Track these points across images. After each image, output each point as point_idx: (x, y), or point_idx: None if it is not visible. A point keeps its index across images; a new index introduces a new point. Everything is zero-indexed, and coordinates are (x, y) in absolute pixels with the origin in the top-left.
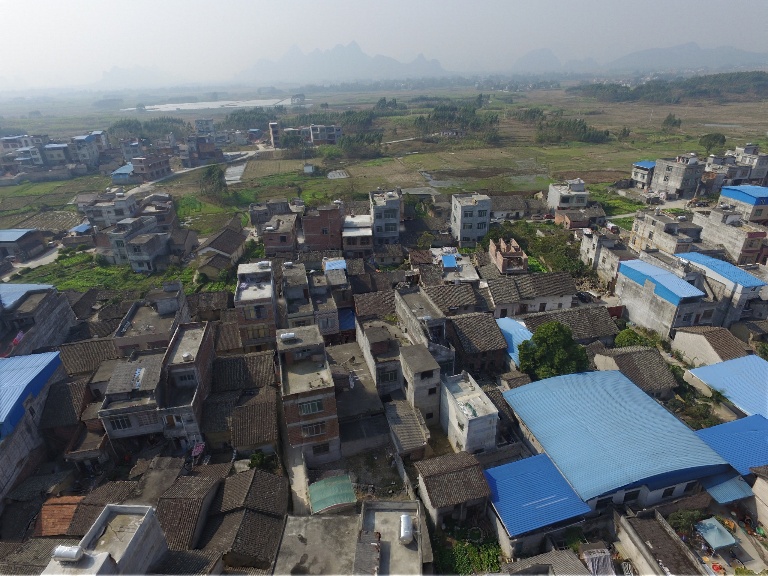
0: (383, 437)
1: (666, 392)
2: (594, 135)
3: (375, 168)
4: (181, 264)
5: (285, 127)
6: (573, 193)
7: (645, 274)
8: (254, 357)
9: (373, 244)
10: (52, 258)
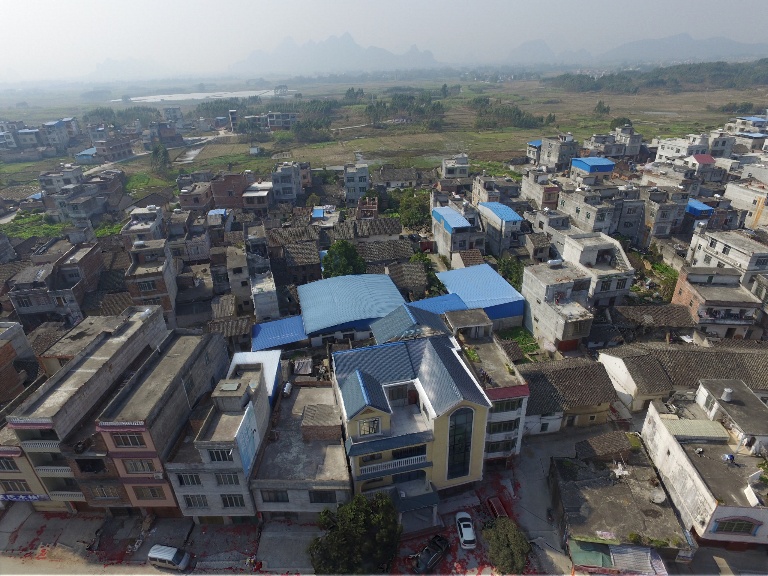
0: (208, 314)
1: (422, 290)
2: (527, 121)
3: (317, 150)
4: (114, 221)
5: (246, 115)
6: (456, 165)
7: (440, 214)
8: None
9: (268, 203)
10: (10, 219)
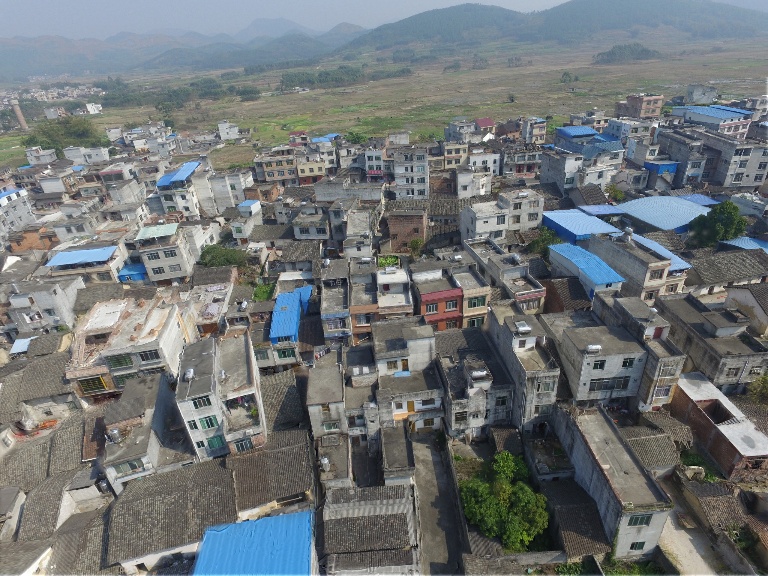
0: None
1: None
2: None
3: None
4: None
5: None
6: None
7: None
8: None
9: None
10: None
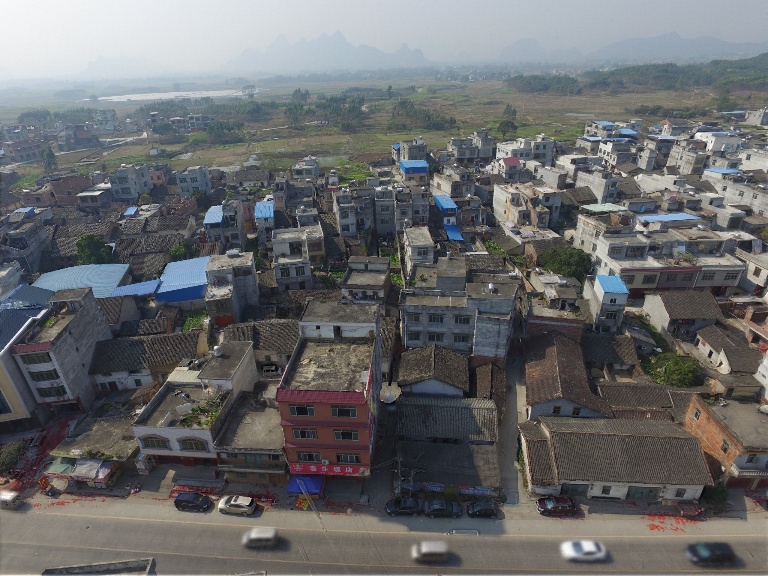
0: None
1: None
2: (435, 123)
3: (219, 151)
4: None
5: (172, 116)
6: (303, 167)
7: None
8: None
9: (102, 202)
10: None
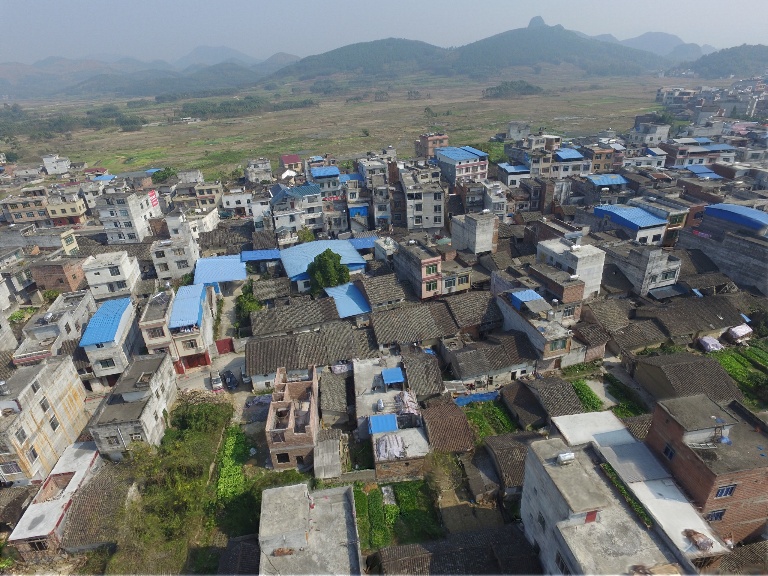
0: None
1: None
2: None
3: None
4: None
5: None
6: None
7: None
8: None
9: None
10: None
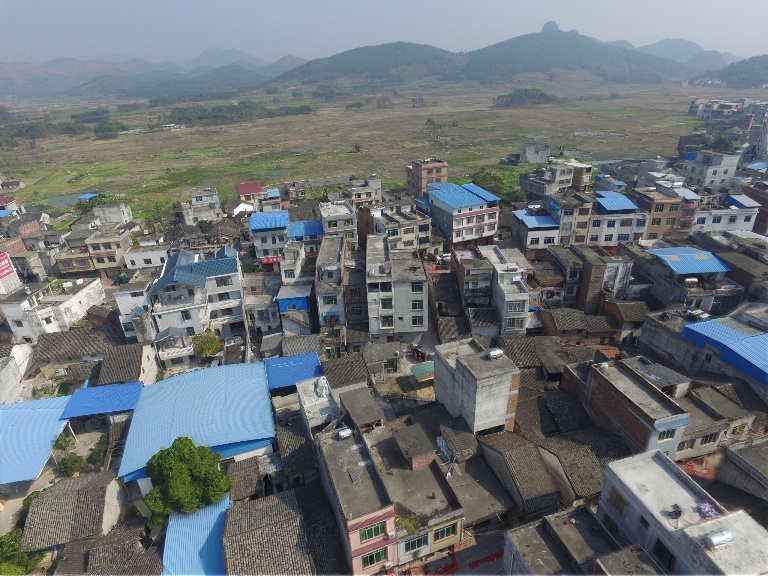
0: None
1: None
2: None
3: None
4: None
5: None
6: None
7: None
8: (577, 449)
9: None
10: None
